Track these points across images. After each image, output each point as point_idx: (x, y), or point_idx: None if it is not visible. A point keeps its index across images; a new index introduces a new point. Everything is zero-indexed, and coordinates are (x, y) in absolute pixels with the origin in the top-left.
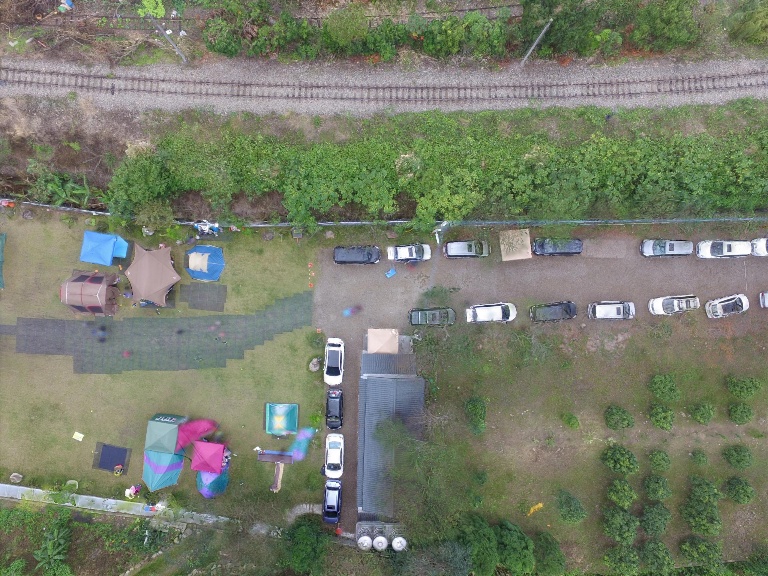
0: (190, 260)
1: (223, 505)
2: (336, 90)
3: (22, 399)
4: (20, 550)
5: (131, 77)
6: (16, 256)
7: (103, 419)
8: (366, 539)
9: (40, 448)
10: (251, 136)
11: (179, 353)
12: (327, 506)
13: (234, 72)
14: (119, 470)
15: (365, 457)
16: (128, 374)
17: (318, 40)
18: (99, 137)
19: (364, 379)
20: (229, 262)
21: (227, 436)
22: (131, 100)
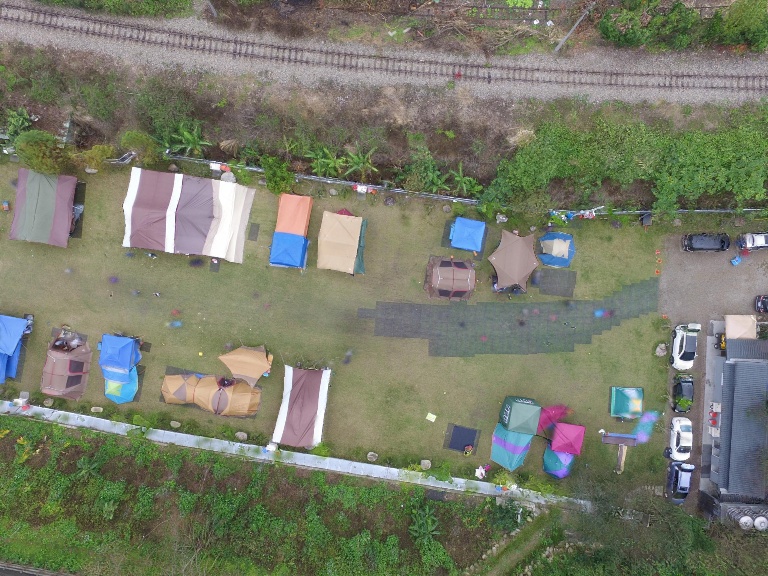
0: (554, 246)
1: (567, 486)
2: (707, 79)
3: (379, 380)
4: (388, 526)
5: (507, 66)
6: (376, 242)
7: (455, 401)
8: (749, 519)
9: (395, 428)
10: (623, 124)
11: (529, 337)
12: (680, 487)
13: (607, 61)
14: (469, 450)
15: (732, 440)
16: (480, 357)
17: (700, 29)
18: (474, 125)
19: (729, 364)
20: (579, 249)
21: (573, 419)
22: (507, 89)
